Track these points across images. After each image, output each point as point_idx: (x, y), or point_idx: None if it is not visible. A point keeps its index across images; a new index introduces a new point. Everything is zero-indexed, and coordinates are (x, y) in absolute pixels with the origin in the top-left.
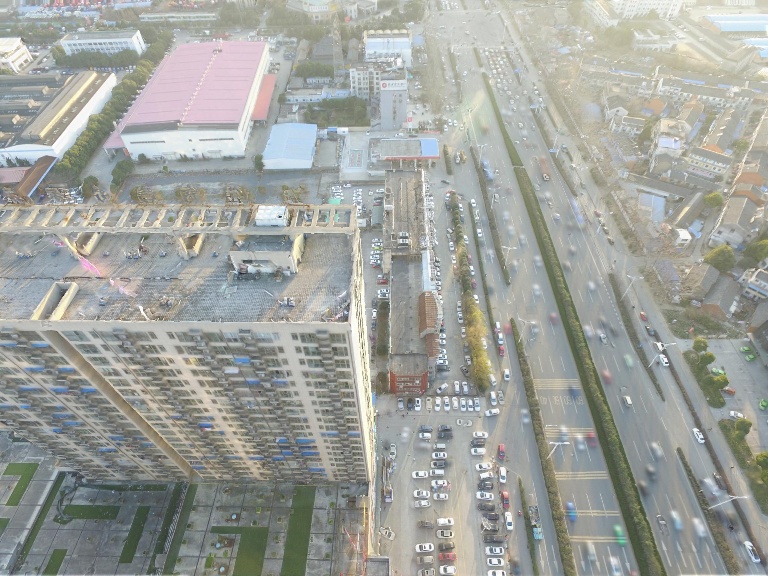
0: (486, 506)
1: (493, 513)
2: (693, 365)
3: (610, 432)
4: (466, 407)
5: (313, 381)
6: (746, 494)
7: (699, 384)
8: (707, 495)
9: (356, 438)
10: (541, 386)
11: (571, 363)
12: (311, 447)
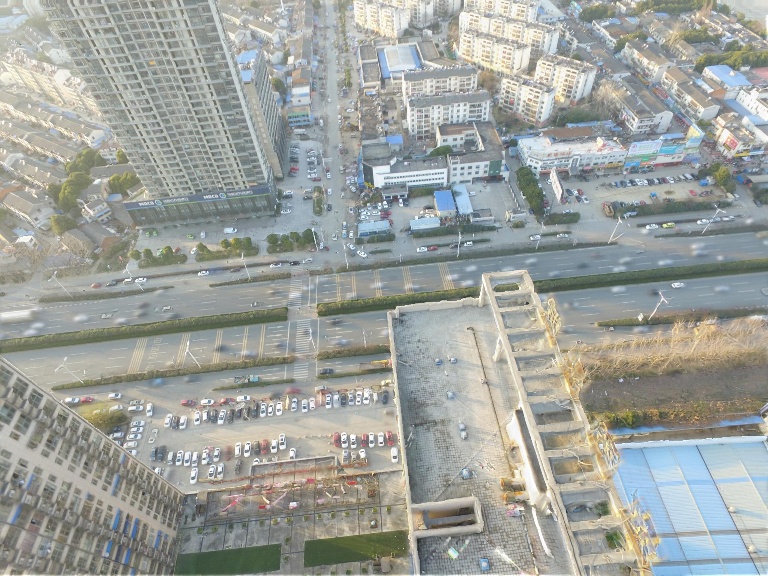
0: (230, 415)
1: (236, 410)
2: (151, 265)
3: (188, 322)
4: (137, 434)
5: (44, 446)
6: (244, 260)
7: (166, 265)
8: (242, 278)
9: (129, 463)
10: (136, 368)
11: (121, 343)
12: (127, 521)
